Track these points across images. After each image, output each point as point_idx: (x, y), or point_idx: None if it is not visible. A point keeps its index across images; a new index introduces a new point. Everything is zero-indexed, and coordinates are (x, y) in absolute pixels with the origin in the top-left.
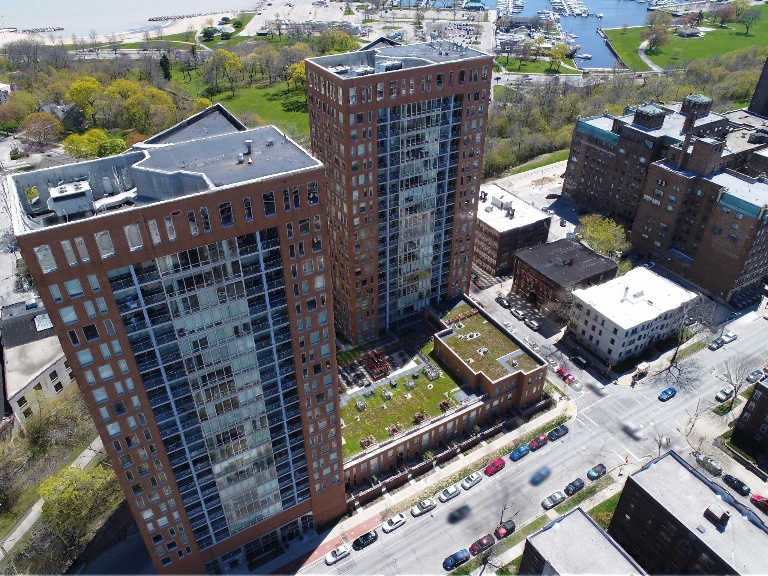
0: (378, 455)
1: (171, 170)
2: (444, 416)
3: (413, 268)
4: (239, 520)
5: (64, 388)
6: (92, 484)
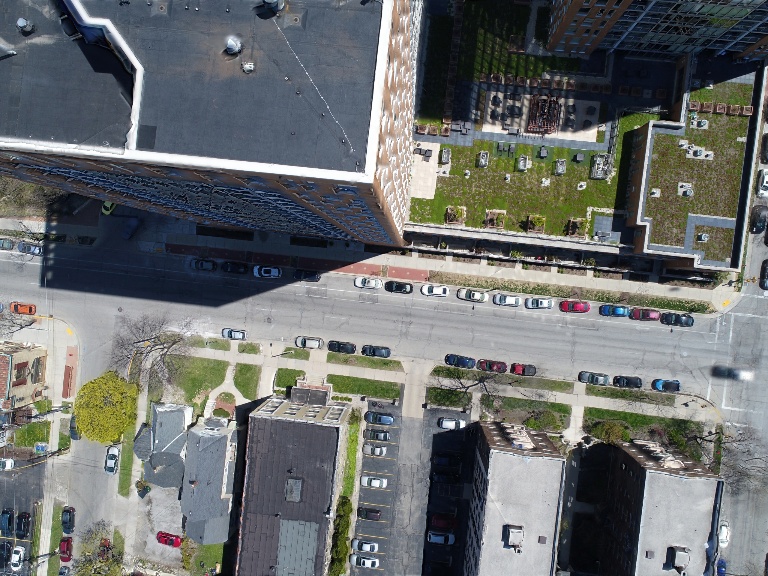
0: (455, 235)
1: (95, 4)
2: (560, 239)
3: (705, 10)
4: (277, 229)
5: None
6: None
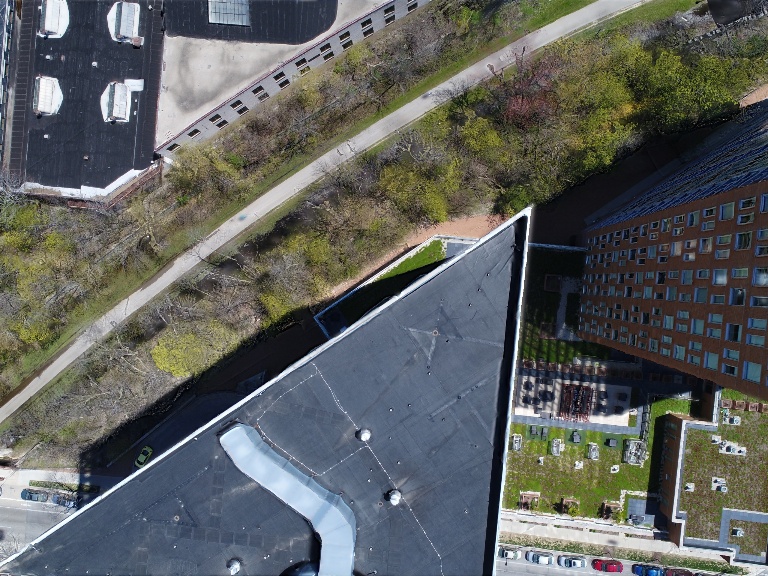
0: None
1: None
2: (594, 522)
3: None
4: None
5: (230, 122)
6: (208, 356)
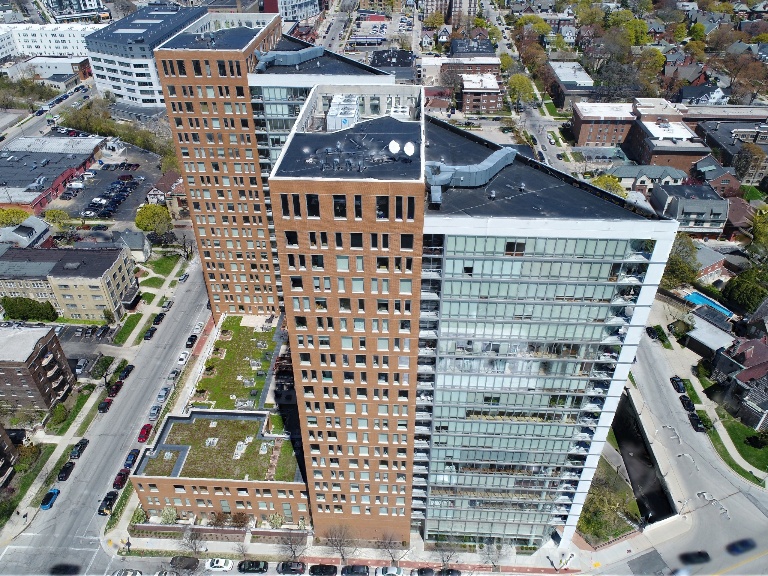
0: None
1: None
2: None
3: None
4: None
5: None
6: None
